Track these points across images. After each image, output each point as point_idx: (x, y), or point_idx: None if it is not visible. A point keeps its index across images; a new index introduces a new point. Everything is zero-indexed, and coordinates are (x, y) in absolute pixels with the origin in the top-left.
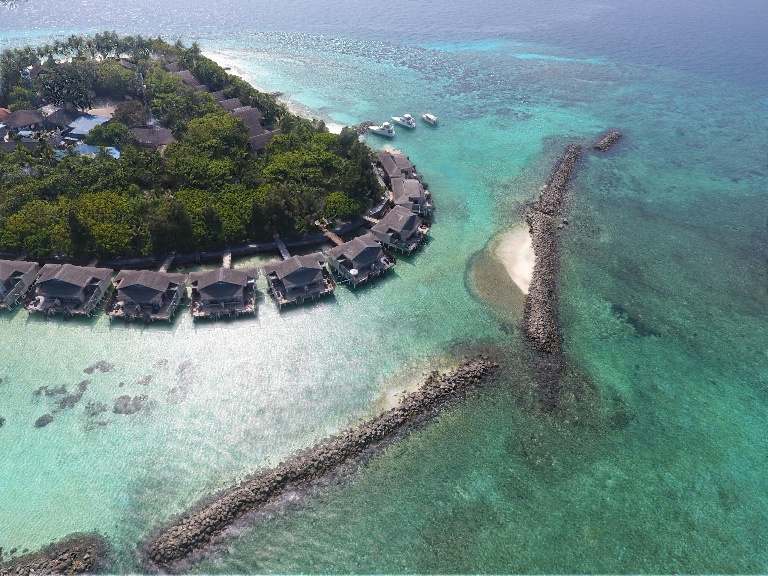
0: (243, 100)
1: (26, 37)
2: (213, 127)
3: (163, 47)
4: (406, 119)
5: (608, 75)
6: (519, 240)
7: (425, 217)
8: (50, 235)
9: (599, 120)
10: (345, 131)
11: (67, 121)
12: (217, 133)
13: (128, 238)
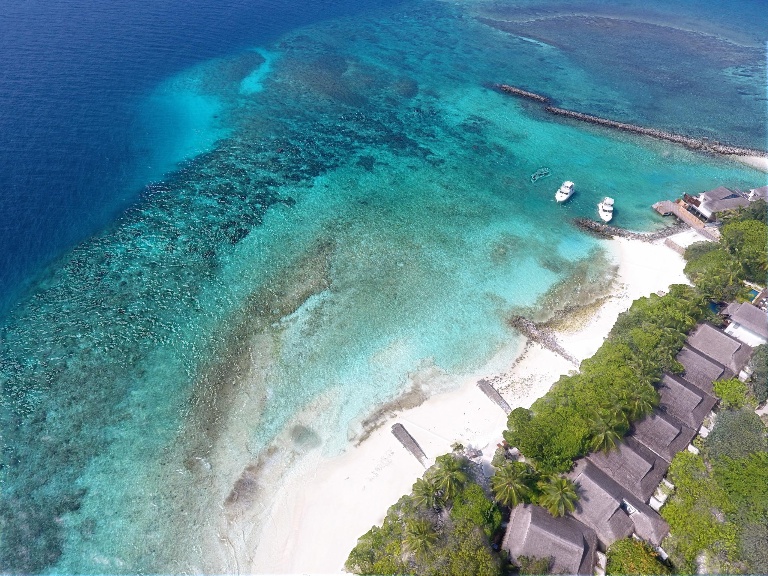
0: None
1: None
2: None
3: (489, 575)
4: (571, 188)
5: (325, 58)
6: (761, 162)
7: None
8: None
9: (468, 87)
10: None
11: None
12: None
13: None
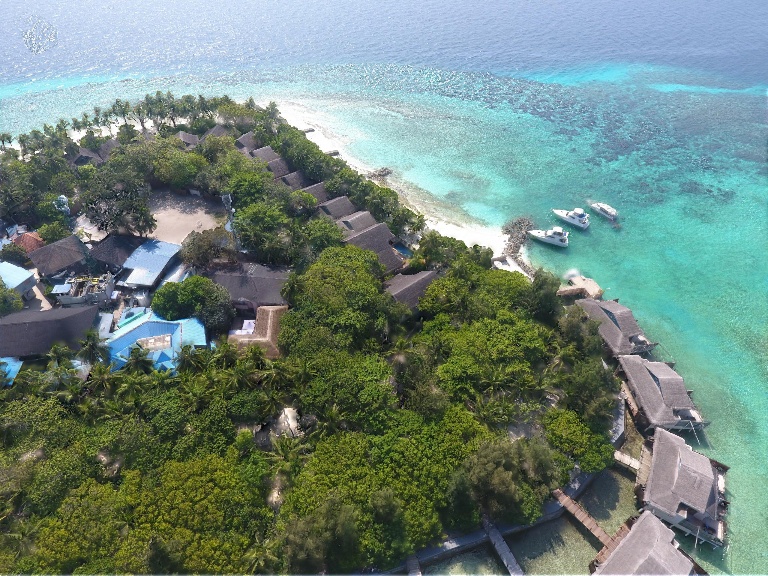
0: (355, 199)
1: (57, 90)
2: (346, 287)
3: (232, 111)
4: (577, 216)
5: None
6: None
7: (691, 434)
8: (114, 567)
9: None
10: (544, 281)
11: (120, 258)
12: (353, 297)
13: (248, 564)
